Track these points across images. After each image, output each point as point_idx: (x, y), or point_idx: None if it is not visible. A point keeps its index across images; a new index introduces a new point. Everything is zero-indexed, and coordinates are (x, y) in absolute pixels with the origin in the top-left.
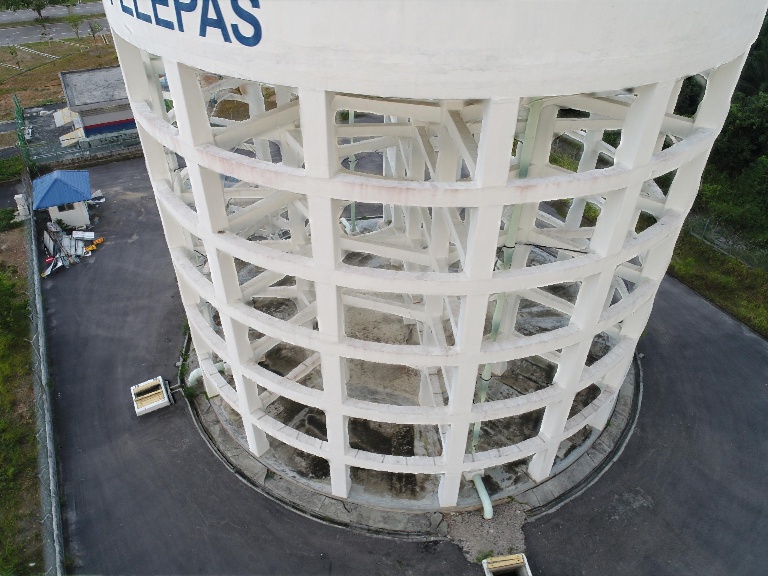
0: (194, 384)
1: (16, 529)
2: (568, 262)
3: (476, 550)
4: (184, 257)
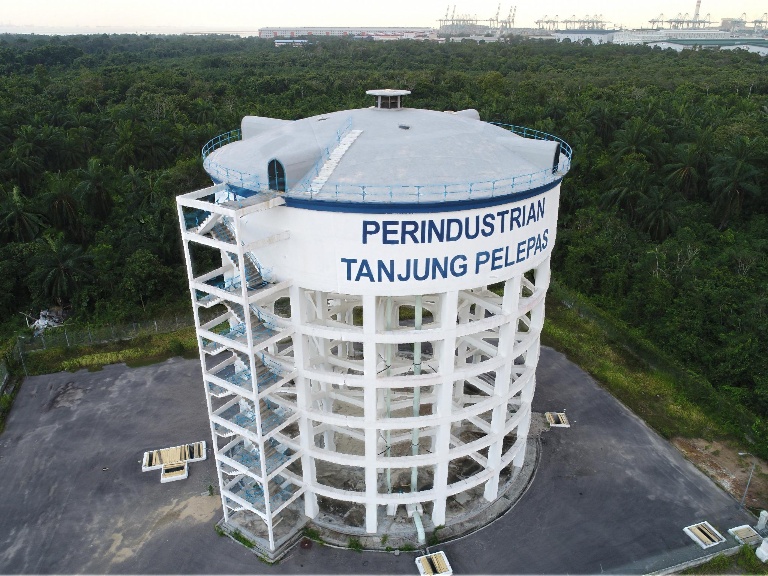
0: (425, 538)
1: None
2: None
3: (544, 427)
4: (461, 409)
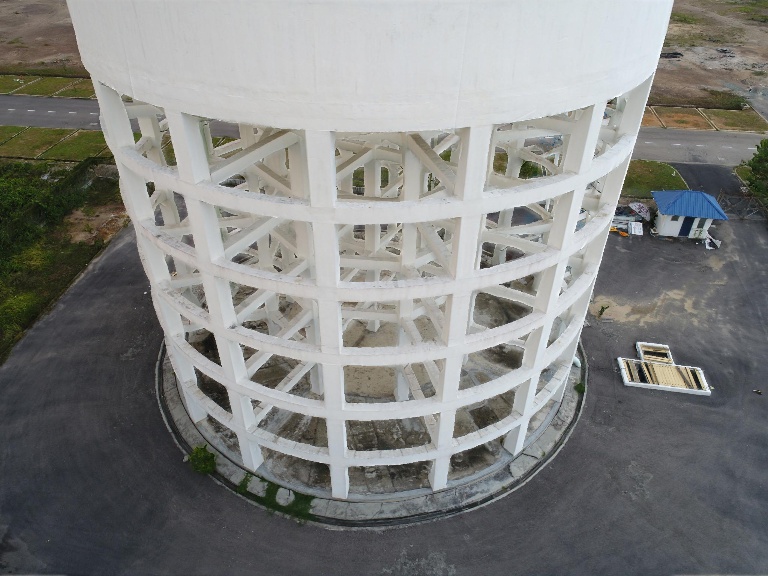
0: None
1: None
2: (164, 123)
3: None
4: None
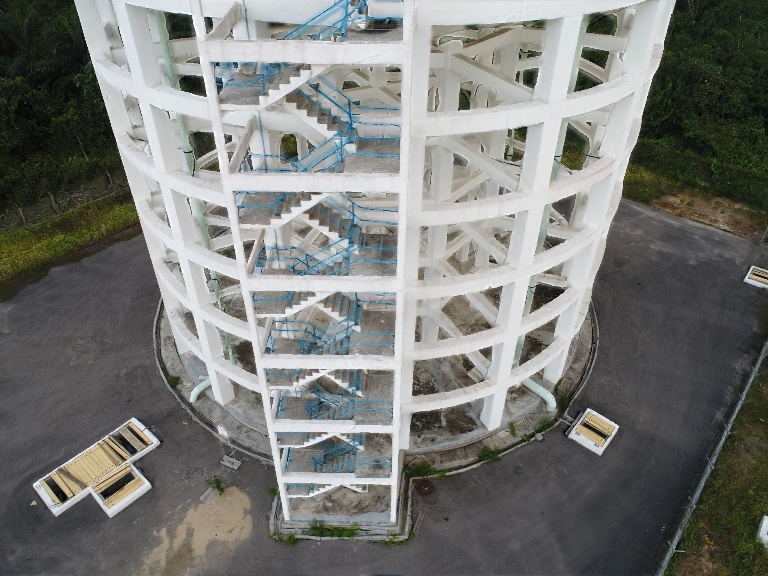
0: None
1: (764, 450)
2: None
3: None
4: None
